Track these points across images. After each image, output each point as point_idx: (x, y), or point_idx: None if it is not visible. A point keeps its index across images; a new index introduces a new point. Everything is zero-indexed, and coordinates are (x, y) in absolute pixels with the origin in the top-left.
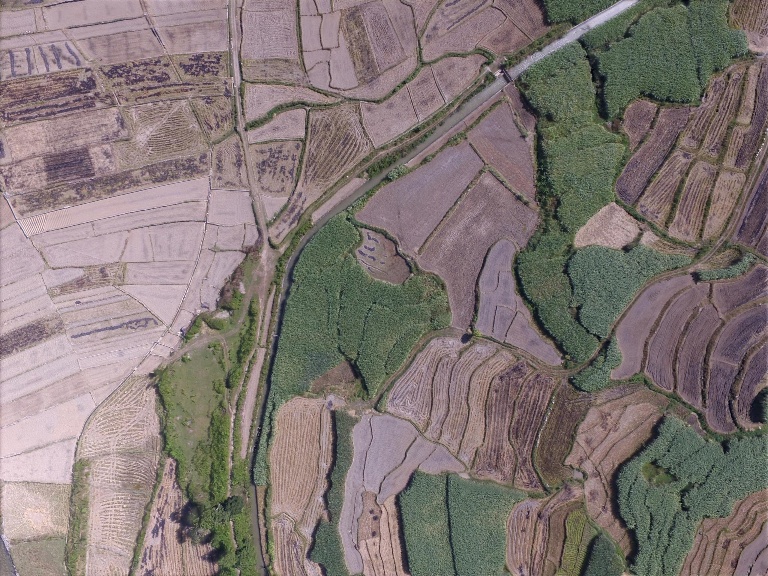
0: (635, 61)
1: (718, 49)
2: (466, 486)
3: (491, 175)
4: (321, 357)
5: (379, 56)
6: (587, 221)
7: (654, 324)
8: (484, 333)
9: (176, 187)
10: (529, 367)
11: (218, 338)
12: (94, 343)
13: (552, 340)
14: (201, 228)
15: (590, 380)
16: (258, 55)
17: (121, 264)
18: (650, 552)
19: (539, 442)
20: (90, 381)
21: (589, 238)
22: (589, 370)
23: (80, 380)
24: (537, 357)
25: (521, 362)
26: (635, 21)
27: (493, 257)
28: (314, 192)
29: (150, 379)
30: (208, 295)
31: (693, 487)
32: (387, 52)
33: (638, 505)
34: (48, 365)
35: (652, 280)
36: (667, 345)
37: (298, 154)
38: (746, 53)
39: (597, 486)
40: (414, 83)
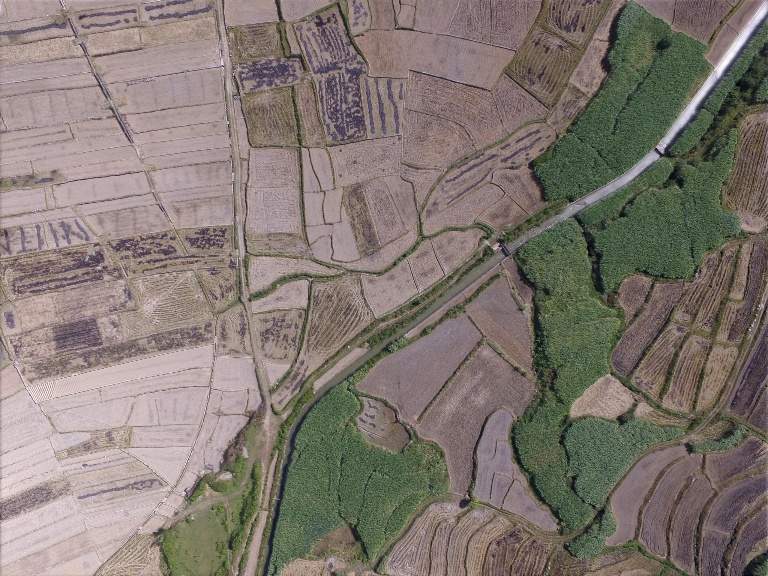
0: (630, 240)
1: (711, 230)
2: None
3: (489, 347)
4: (322, 522)
5: (380, 230)
6: (583, 393)
7: (648, 493)
8: (482, 499)
9: (181, 354)
10: (525, 533)
11: (221, 500)
12: (100, 504)
13: (548, 506)
14: (205, 393)
15: (585, 549)
16: (262, 229)
17: (127, 428)
18: None
19: None
20: (96, 540)
21: (585, 408)
22: (584, 539)
23: (86, 539)
24: (533, 523)
25: (518, 528)
26: (630, 200)
27: (491, 426)
28: (316, 360)
29: (155, 537)
30: (212, 457)
31: None
32: (388, 226)
33: None
34: (55, 525)
35: (646, 450)
36: (661, 513)
37: (301, 323)
38: (739, 233)
39: None
40: (414, 256)
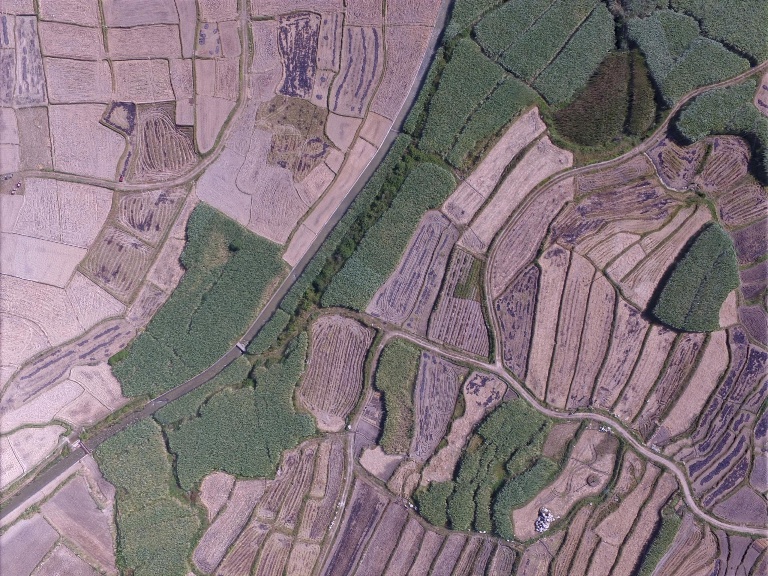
0: (204, 441)
1: (283, 432)
2: None
3: (66, 548)
4: None
5: None
6: None
7: None
8: None
9: None
10: None
11: None
12: None
13: None
14: None
15: None
16: None
17: None
18: None
19: None
20: None
21: None
22: None
23: None
24: None
25: None
26: (207, 399)
27: None
28: None
29: None
30: None
31: None
32: None
33: None
34: None
35: None
36: None
37: None
38: (315, 433)
39: None
40: None
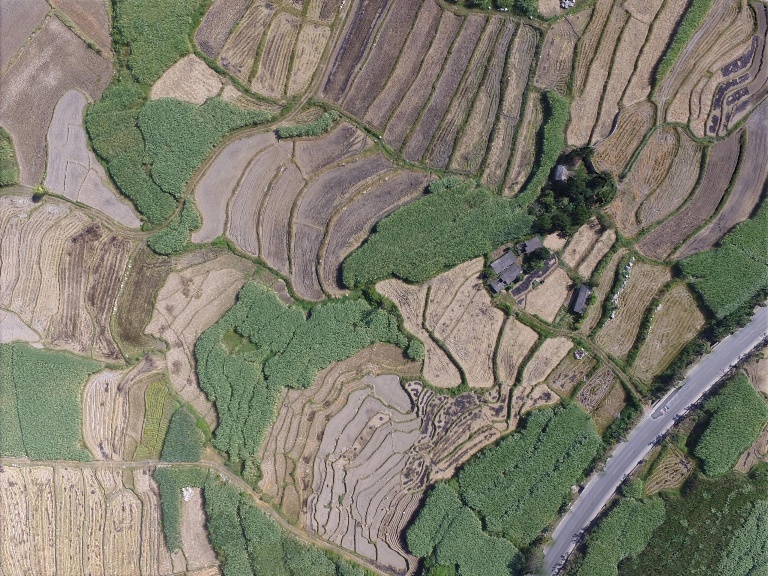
0: None
1: None
2: (32, 354)
3: (58, 20)
4: None
5: None
6: (160, 72)
7: (236, 184)
8: (55, 191)
9: None
10: (105, 229)
11: None
12: None
13: (131, 201)
14: None
15: (163, 241)
16: None
17: None
18: (230, 424)
19: (117, 309)
20: None
21: (167, 91)
22: (163, 231)
23: None
24: (114, 218)
25: (96, 223)
26: None
27: (62, 109)
28: None
29: None
30: None
31: (274, 355)
32: None
33: (217, 375)
34: None
35: (233, 137)
36: (250, 207)
37: None
38: None
39: (181, 357)
40: None
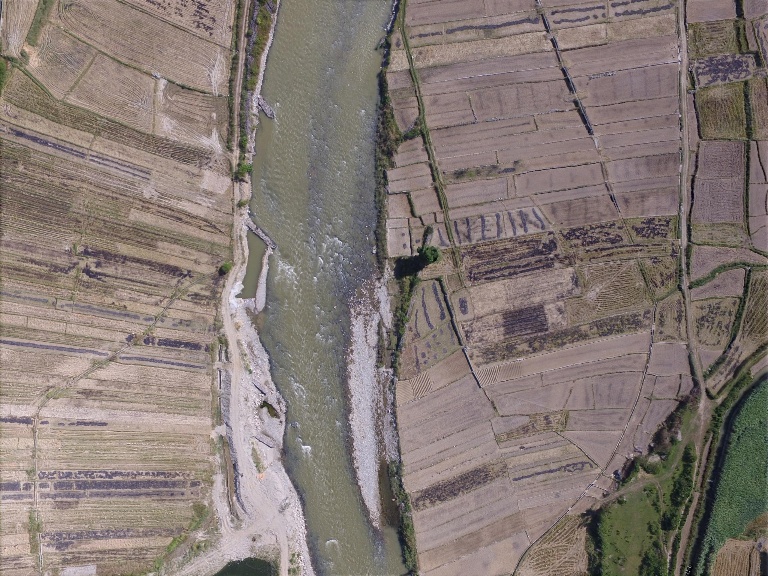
0: None
1: None
2: None
3: None
4: (757, 503)
5: None
6: None
7: None
8: None
9: (620, 340)
10: None
11: (653, 482)
12: (534, 485)
13: None
14: (639, 378)
15: None
16: (706, 219)
17: (564, 412)
18: None
19: None
20: (527, 521)
21: None
22: None
23: (518, 520)
24: None
25: None
26: None
27: None
28: (750, 346)
29: (582, 518)
30: (641, 440)
31: None
32: None
33: None
34: (490, 506)
35: None
36: None
37: (735, 310)
38: None
39: None
40: None
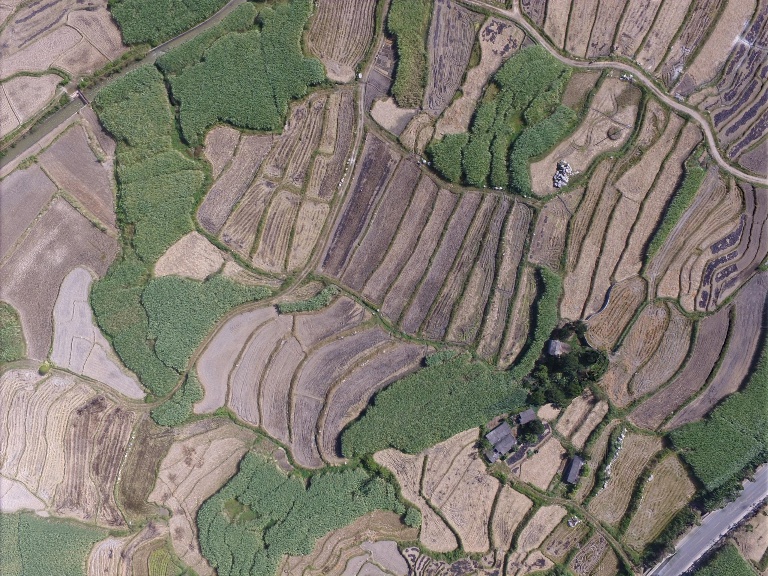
0: (208, 86)
1: (291, 77)
2: (37, 525)
3: (64, 201)
4: None
5: None
6: (164, 250)
7: (237, 357)
8: (60, 365)
9: None
10: (109, 401)
11: None
12: None
13: (135, 373)
14: None
15: (166, 415)
16: None
17: None
18: None
19: (121, 478)
20: None
21: (170, 267)
22: (166, 404)
23: None
24: (118, 390)
25: (100, 395)
26: (211, 45)
27: (67, 286)
28: None
29: None
30: None
31: (274, 524)
32: None
33: (218, 543)
34: None
35: (234, 312)
36: (251, 378)
37: None
38: (324, 81)
39: (183, 523)
40: None
